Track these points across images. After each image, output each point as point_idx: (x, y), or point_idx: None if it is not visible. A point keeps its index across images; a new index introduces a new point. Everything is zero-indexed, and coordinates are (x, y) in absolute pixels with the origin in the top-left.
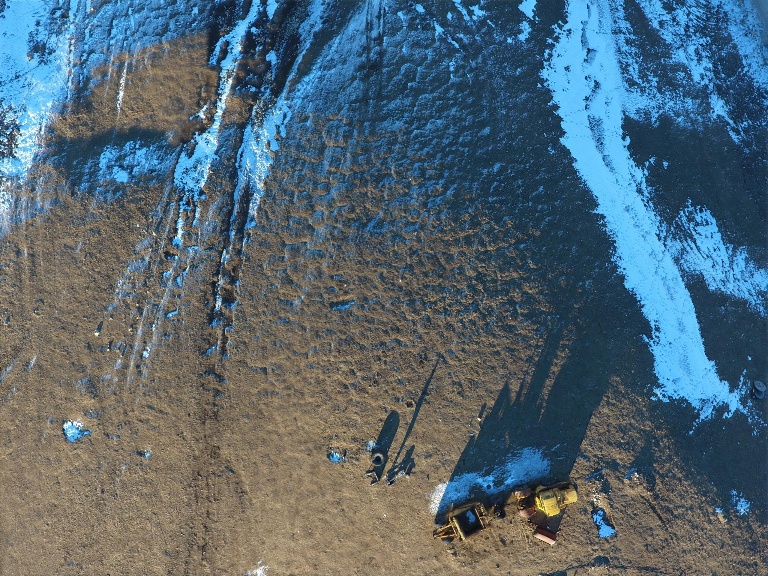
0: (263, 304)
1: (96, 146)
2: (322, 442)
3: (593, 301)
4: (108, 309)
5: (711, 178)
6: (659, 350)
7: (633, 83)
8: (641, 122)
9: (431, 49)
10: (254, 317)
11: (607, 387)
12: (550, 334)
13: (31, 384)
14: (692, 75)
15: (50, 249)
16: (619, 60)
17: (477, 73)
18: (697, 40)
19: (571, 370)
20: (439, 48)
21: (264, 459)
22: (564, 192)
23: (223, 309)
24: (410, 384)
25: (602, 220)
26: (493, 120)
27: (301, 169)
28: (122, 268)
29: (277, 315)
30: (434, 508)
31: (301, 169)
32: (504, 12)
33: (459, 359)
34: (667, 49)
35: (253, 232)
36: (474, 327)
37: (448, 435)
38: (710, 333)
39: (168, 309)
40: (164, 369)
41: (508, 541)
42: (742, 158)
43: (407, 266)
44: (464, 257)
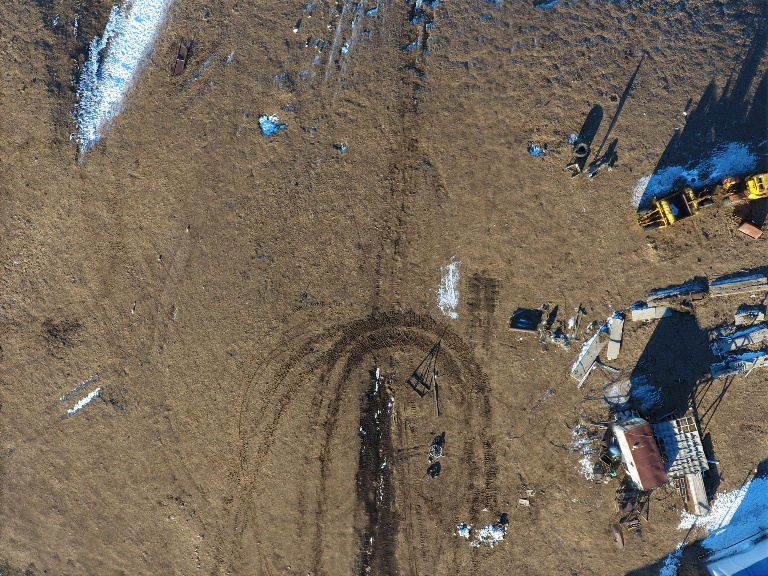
0: (465, 1)
1: None
2: (523, 135)
3: None
4: (307, 7)
5: None
6: None
7: None
8: None
9: None
10: (456, 13)
11: None
12: (757, 35)
13: (228, 78)
14: None
15: None
16: None
17: None
18: None
19: None
20: None
21: (463, 152)
22: None
23: (424, 6)
24: (614, 79)
25: None
26: None
27: None
28: None
29: (479, 12)
30: (636, 202)
31: None
32: None
33: (665, 55)
34: None
35: None
36: (680, 25)
37: (653, 129)
38: None
39: (368, 7)
40: (363, 63)
41: (711, 235)
42: None
43: None
44: None
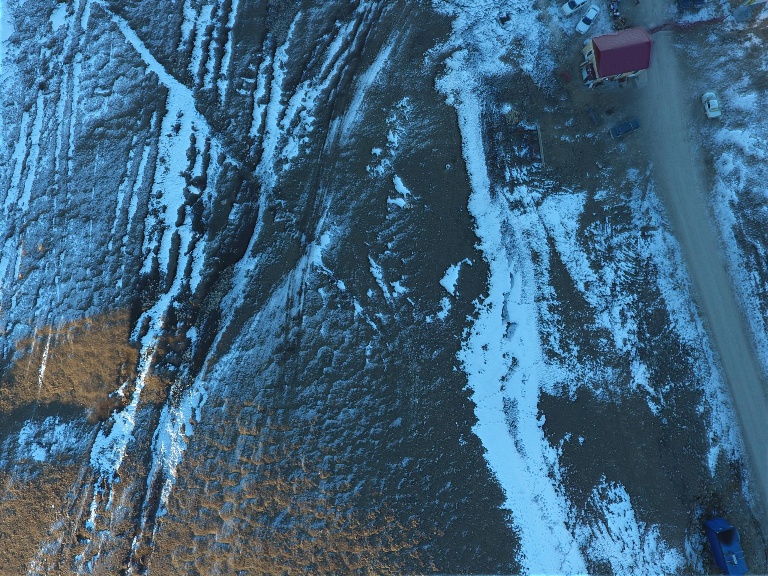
0: None
1: (16, 420)
2: None
3: None
4: None
5: (627, 454)
6: None
7: (553, 354)
8: (558, 398)
9: (349, 331)
10: None
11: None
12: None
13: None
14: (615, 341)
15: None
16: (540, 330)
17: (393, 358)
18: (623, 300)
19: None
20: (357, 330)
21: None
22: (472, 488)
23: None
24: None
25: (509, 516)
26: (405, 410)
27: (213, 457)
28: (36, 549)
29: None
30: None
31: (213, 457)
32: (425, 288)
33: None
34: (591, 314)
35: (163, 521)
36: None
37: None
38: None
39: None
40: None
41: None
42: (659, 431)
43: (312, 565)
44: (368, 558)
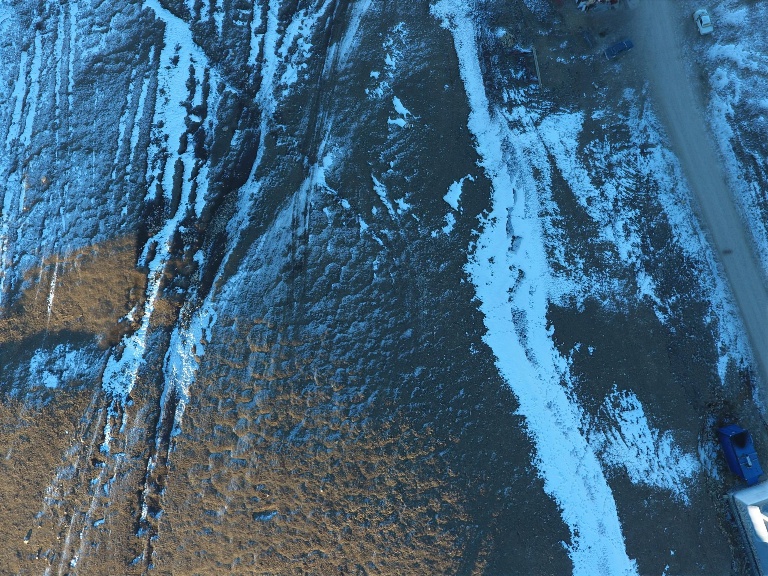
0: (187, 514)
1: (27, 350)
2: None
3: (512, 509)
4: (37, 517)
5: (636, 362)
6: (578, 556)
7: (559, 267)
8: (566, 308)
9: (355, 247)
10: (179, 527)
11: None
12: (469, 545)
13: None
14: (619, 253)
15: None
16: (545, 244)
17: (400, 271)
18: (625, 214)
19: None
20: (363, 246)
21: None
22: (485, 395)
23: (149, 518)
24: None
25: (523, 421)
26: (415, 321)
27: (226, 375)
28: (51, 475)
29: (201, 525)
30: None
31: (226, 375)
32: (429, 204)
33: (379, 571)
34: (594, 228)
35: (178, 440)
36: (394, 538)
37: None
38: (632, 530)
39: (95, 518)
40: None
41: None
42: (668, 339)
43: (328, 476)
44: (384, 466)
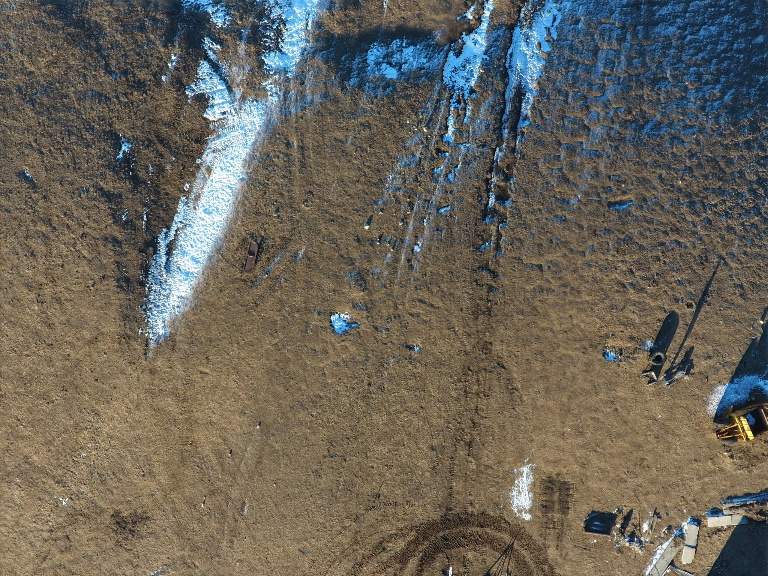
0: (539, 202)
1: (363, 43)
2: (598, 341)
3: None
4: (378, 203)
5: None
6: None
7: None
8: None
9: None
10: (530, 214)
11: None
12: None
13: (299, 275)
14: None
15: (320, 142)
16: None
17: None
18: None
19: None
20: None
21: (538, 356)
22: None
23: (497, 206)
24: (690, 285)
25: None
26: (766, 29)
27: (575, 70)
28: (392, 163)
29: (553, 213)
30: (712, 410)
31: (575, 70)
32: None
33: (741, 262)
34: None
35: (527, 131)
36: (756, 231)
37: (729, 337)
38: None
39: (440, 204)
40: (436, 263)
41: None
42: None
43: (686, 168)
44: (744, 161)
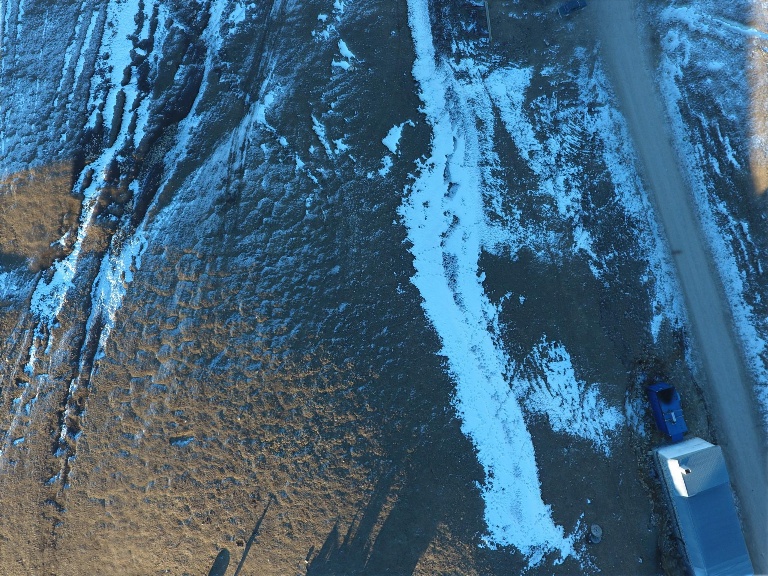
0: (105, 436)
1: None
2: (155, 575)
3: (427, 446)
4: None
5: (567, 314)
6: (491, 497)
7: (495, 216)
8: (499, 257)
9: (290, 184)
10: (96, 449)
11: (434, 534)
12: (381, 479)
13: None
14: (558, 207)
15: None
16: (483, 193)
17: (333, 210)
18: (568, 170)
19: (400, 516)
20: (297, 183)
21: None
22: (408, 334)
23: (67, 439)
24: (242, 523)
25: (445, 362)
26: (343, 259)
27: (152, 302)
28: None
29: (118, 448)
30: None
31: (152, 302)
32: (367, 146)
33: (290, 500)
34: (534, 181)
35: (101, 363)
36: (307, 469)
37: (276, 575)
38: (549, 476)
39: (15, 436)
40: (7, 495)
41: None
42: (601, 294)
43: (246, 405)
44: (302, 398)
